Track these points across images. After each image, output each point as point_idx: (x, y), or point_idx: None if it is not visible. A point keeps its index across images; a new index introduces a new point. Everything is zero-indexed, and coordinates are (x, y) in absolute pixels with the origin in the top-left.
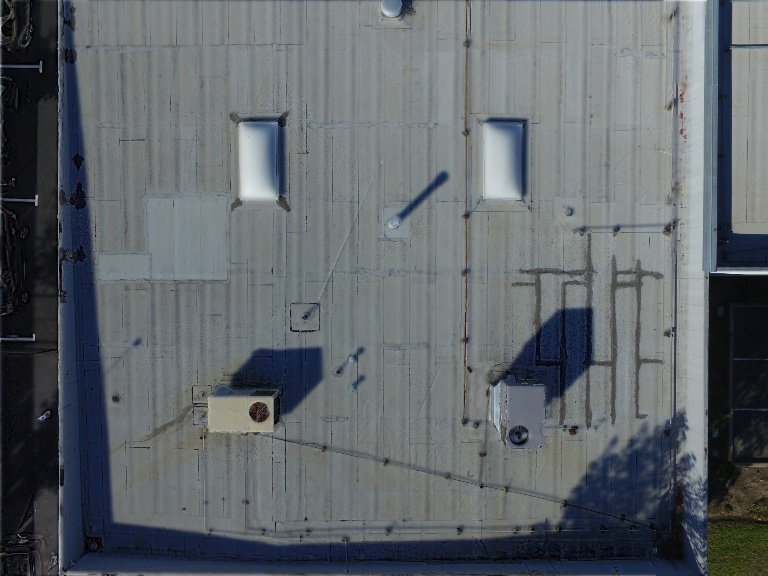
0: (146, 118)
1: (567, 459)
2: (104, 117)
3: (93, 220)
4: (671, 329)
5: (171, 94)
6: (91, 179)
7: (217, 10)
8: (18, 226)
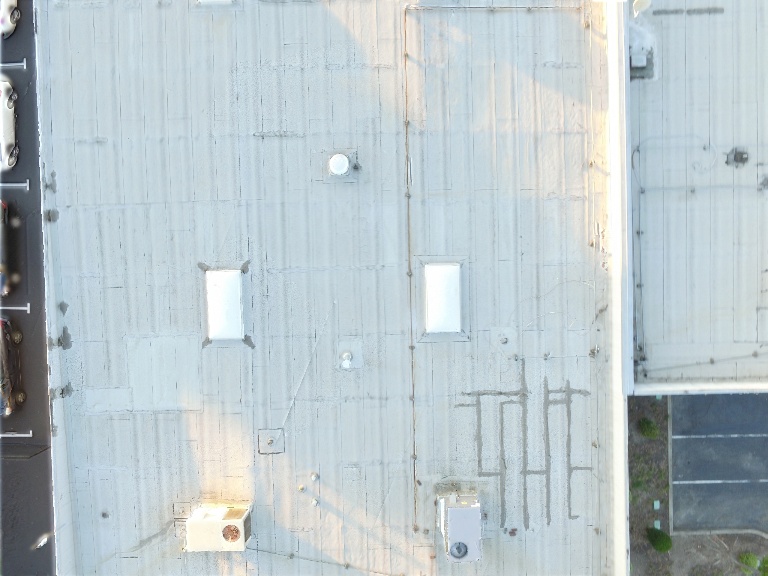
0: (123, 268)
1: (508, 557)
2: (85, 268)
3: (79, 359)
4: (597, 441)
5: (145, 246)
6: (76, 323)
7: (183, 171)
8: (12, 332)
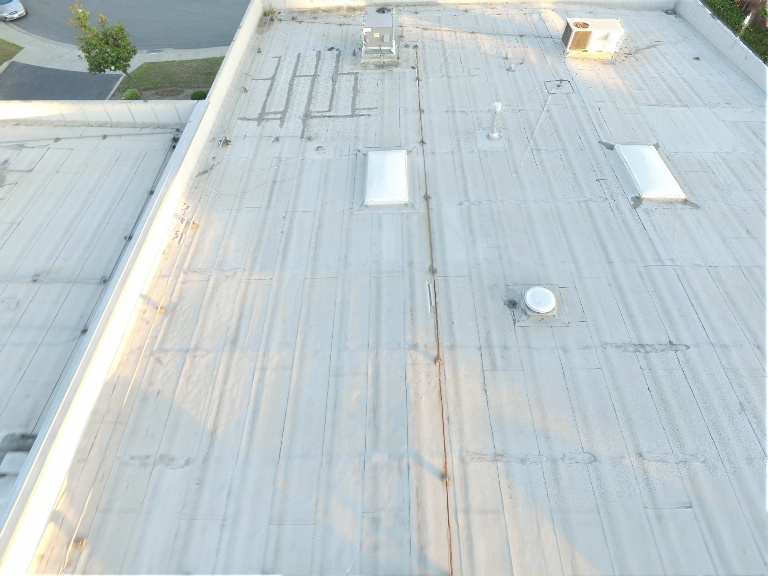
0: None
1: None
2: None
3: None
4: (242, 89)
5: None
6: None
7: None
8: None
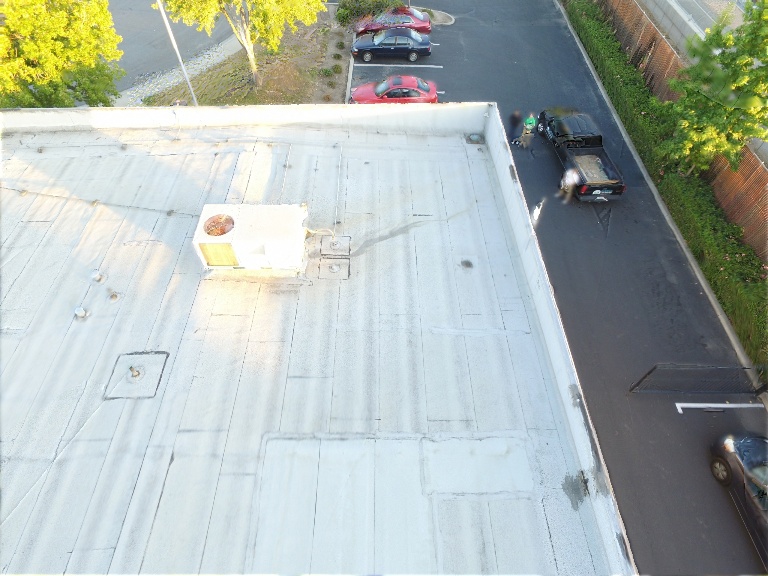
0: None
1: None
2: None
3: None
4: None
5: None
6: None
7: None
8: None
